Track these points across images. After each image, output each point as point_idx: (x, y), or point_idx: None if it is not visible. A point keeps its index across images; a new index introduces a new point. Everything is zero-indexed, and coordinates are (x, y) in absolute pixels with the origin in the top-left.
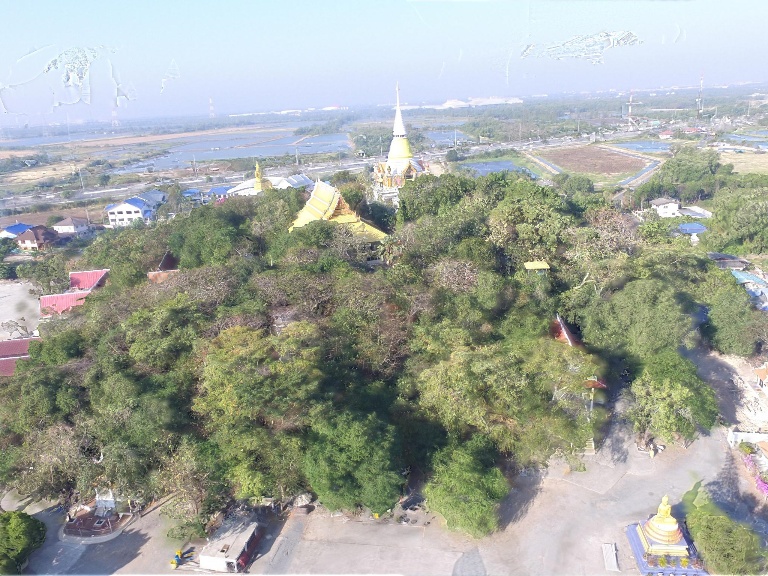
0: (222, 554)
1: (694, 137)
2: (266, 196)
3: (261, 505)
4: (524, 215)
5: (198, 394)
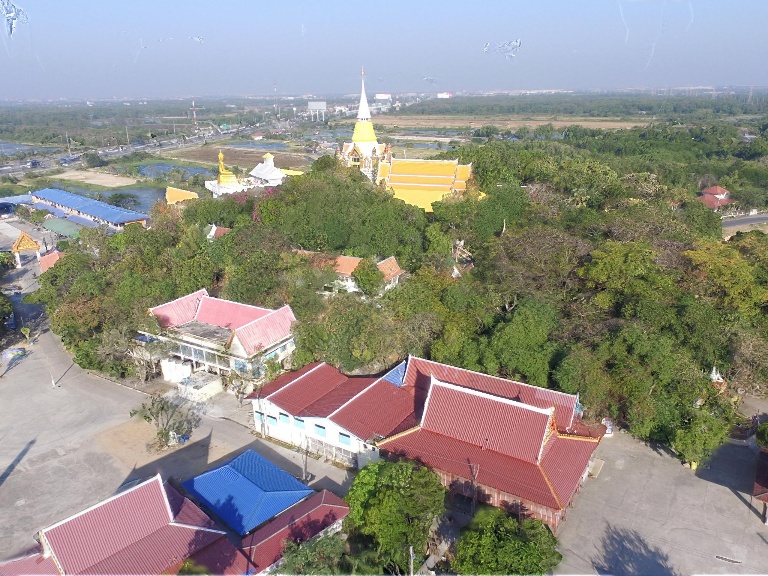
0: None
1: (284, 137)
2: None
3: None
4: (595, 169)
5: None
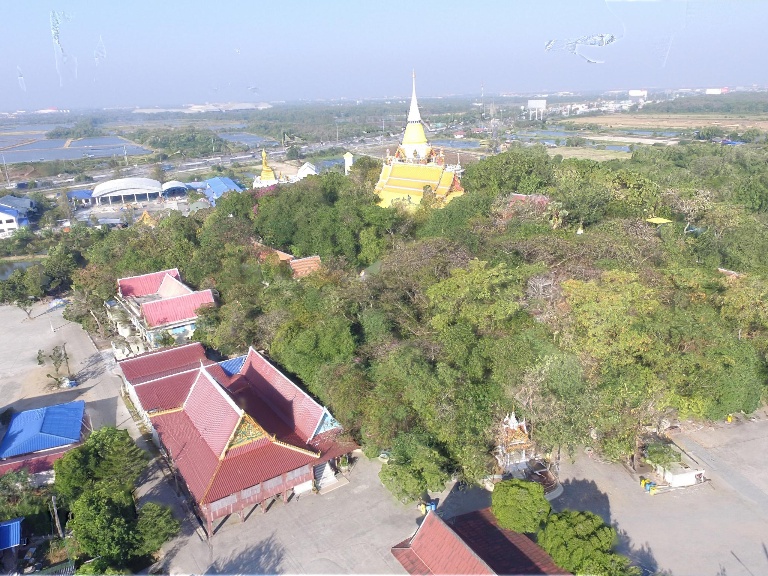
0: (690, 469)
1: (484, 136)
2: (316, 182)
3: (651, 432)
4: (625, 182)
5: (559, 347)
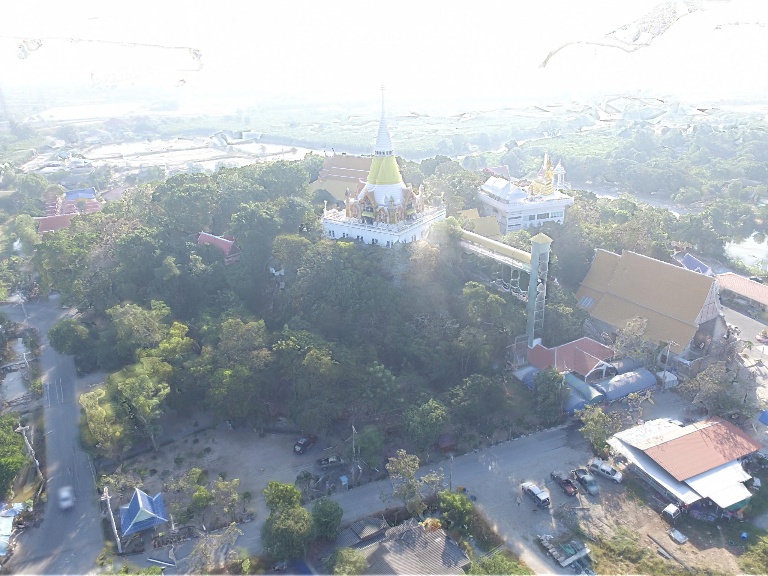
0: None
1: None
2: None
3: None
4: None
5: None
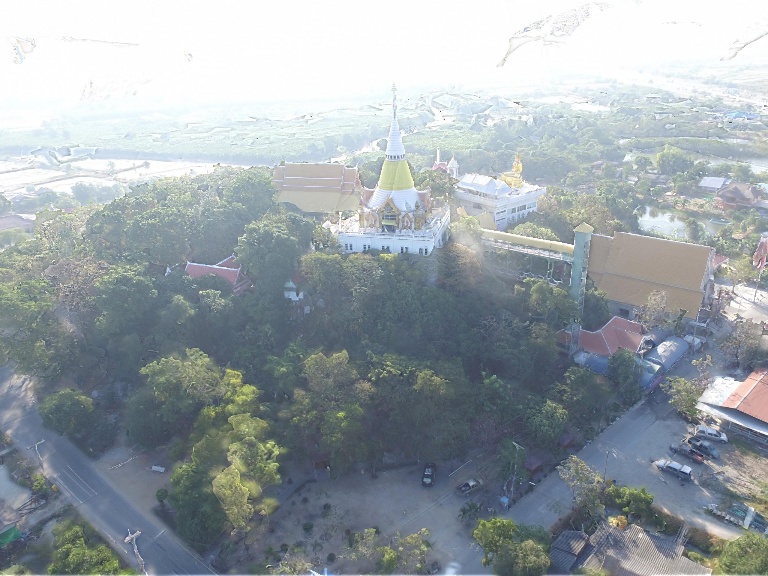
0: None
1: None
2: None
3: None
4: None
5: None
